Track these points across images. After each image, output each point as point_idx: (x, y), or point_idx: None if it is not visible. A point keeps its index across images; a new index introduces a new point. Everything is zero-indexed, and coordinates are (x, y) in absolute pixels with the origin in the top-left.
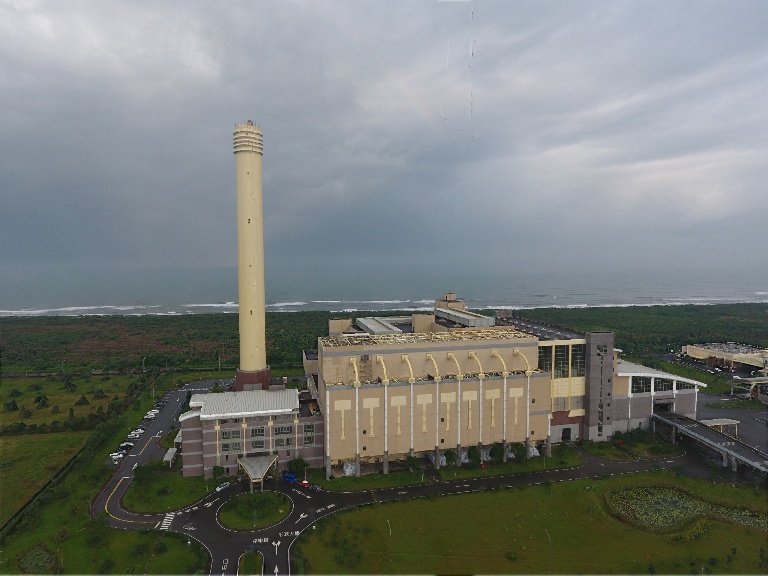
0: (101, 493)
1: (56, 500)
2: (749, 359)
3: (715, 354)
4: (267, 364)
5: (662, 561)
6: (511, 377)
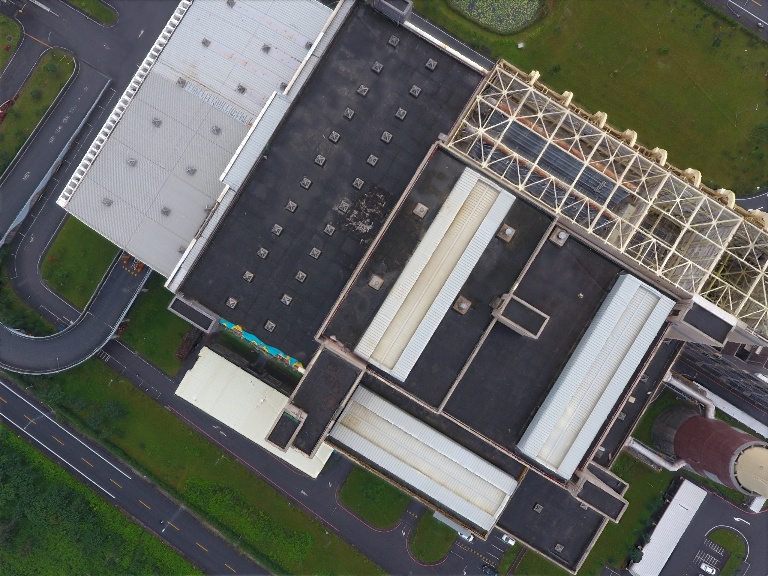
0: None
1: None
2: None
3: None
4: None
5: None
6: (556, 94)
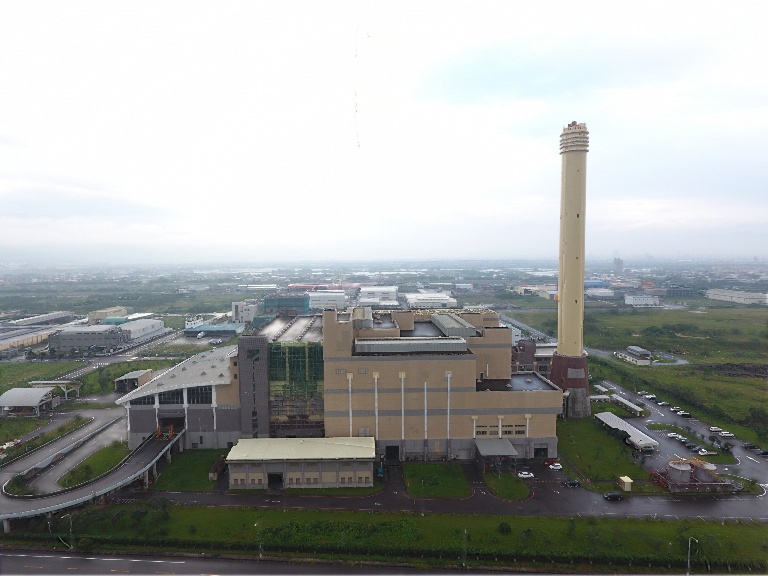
0: None
1: None
2: None
3: None
4: None
5: None
6: None
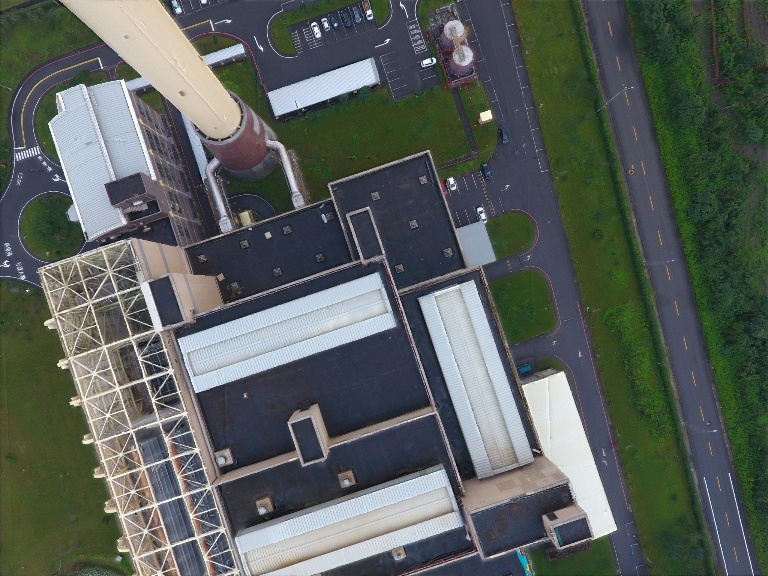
0: (64, 58)
1: (42, 24)
2: None
3: None
4: (636, 28)
5: (9, 575)
6: None
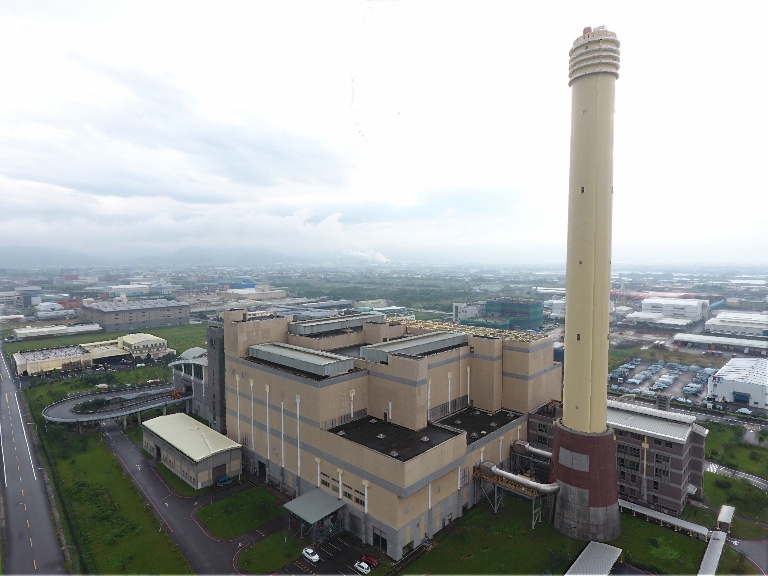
0: None
1: None
2: (109, 352)
3: (70, 359)
4: None
5: None
6: None
